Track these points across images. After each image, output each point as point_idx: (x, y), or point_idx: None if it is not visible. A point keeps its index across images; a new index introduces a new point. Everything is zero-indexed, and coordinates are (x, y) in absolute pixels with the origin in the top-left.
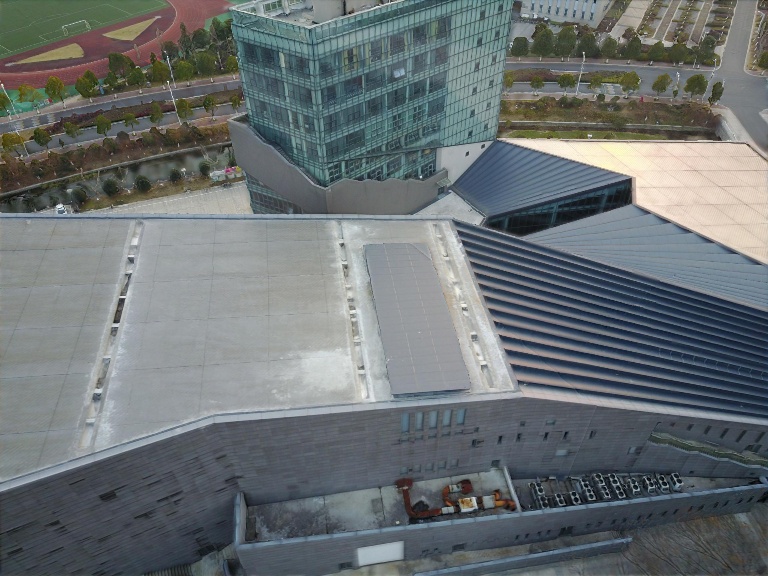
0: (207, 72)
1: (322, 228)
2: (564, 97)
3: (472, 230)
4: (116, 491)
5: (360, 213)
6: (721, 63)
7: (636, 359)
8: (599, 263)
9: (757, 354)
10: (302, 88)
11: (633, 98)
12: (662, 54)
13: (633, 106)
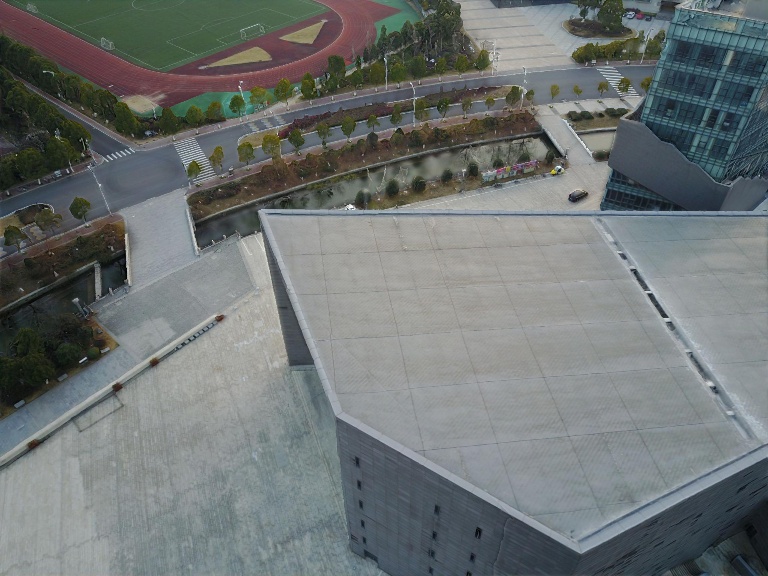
0: (419, 74)
1: (767, 225)
2: None
3: None
4: (749, 484)
5: None
6: None
7: None
8: None
9: None
10: (742, 86)
11: None
12: None
13: None
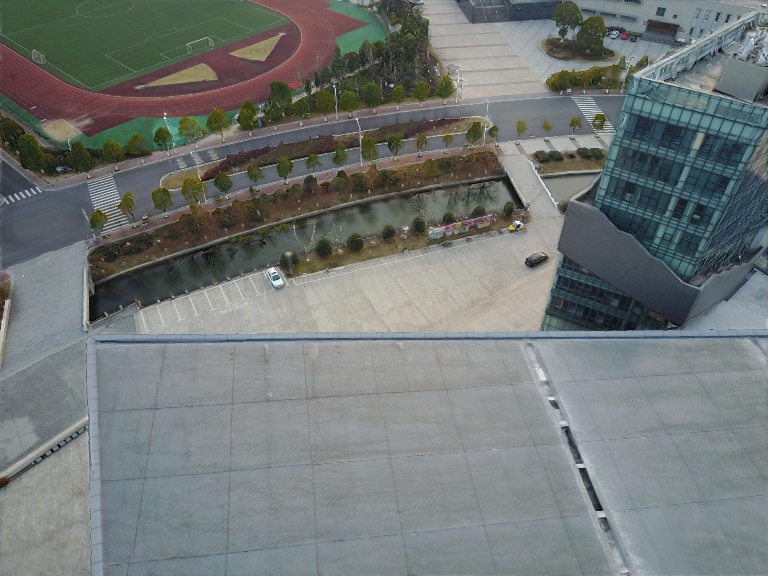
0: (373, 103)
1: (742, 351)
2: None
3: None
4: None
5: (701, 308)
6: None
7: None
8: None
9: None
10: (716, 175)
11: None
12: None
13: None
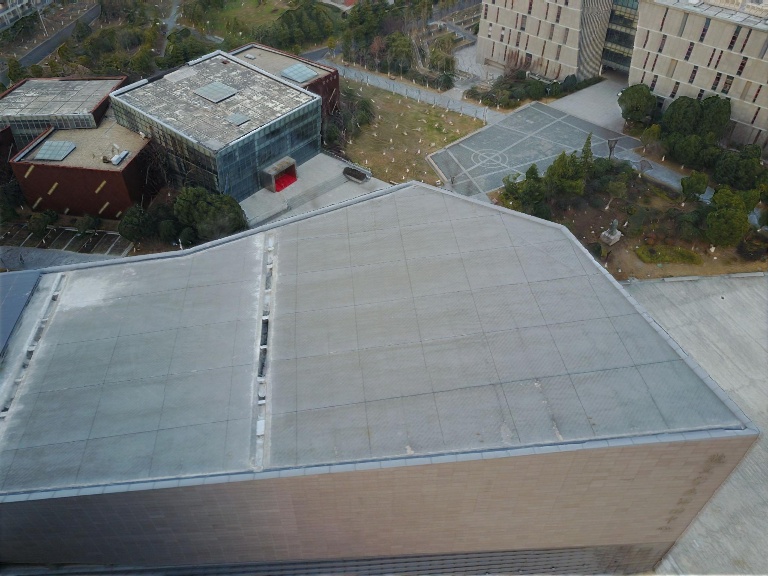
0: None
1: None
2: None
3: None
4: None
5: None
6: None
7: None
8: None
9: None
10: None
11: None
12: None
13: None
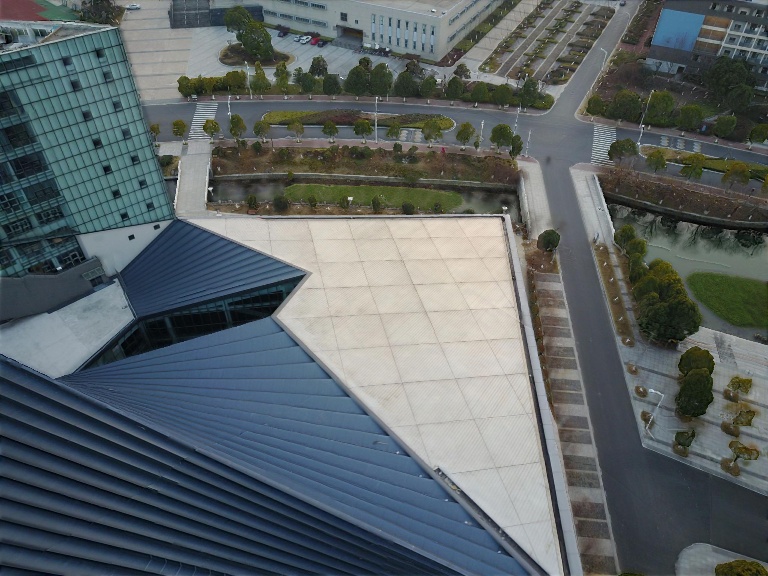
0: None
1: None
2: (353, 147)
3: (6, 367)
4: None
5: None
6: (553, 106)
7: (107, 574)
8: (133, 421)
9: (282, 562)
10: None
11: (438, 147)
12: (484, 96)
13: (431, 158)
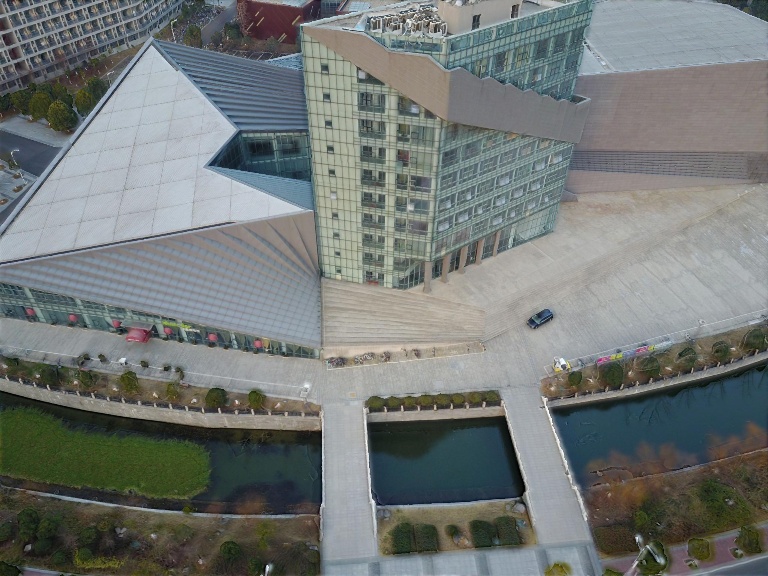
0: None
1: None
2: (50, 522)
3: None
4: None
5: None
6: None
7: None
8: None
9: None
10: None
11: None
12: None
13: None
